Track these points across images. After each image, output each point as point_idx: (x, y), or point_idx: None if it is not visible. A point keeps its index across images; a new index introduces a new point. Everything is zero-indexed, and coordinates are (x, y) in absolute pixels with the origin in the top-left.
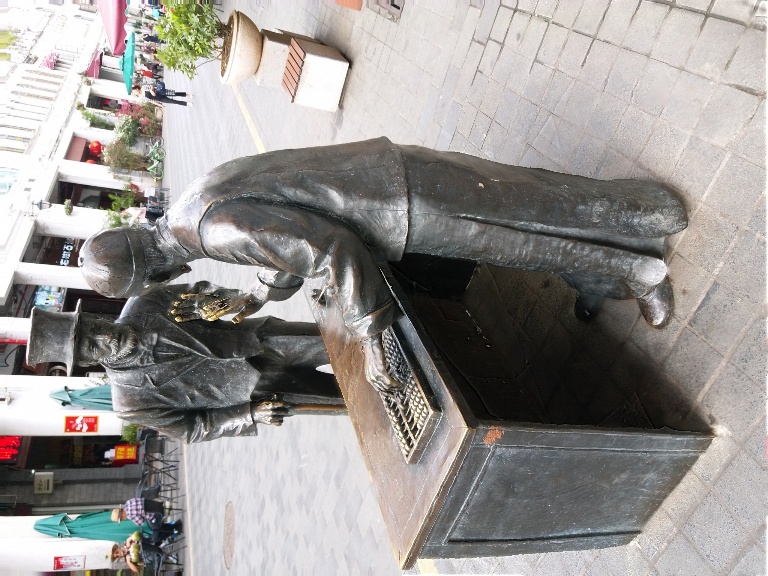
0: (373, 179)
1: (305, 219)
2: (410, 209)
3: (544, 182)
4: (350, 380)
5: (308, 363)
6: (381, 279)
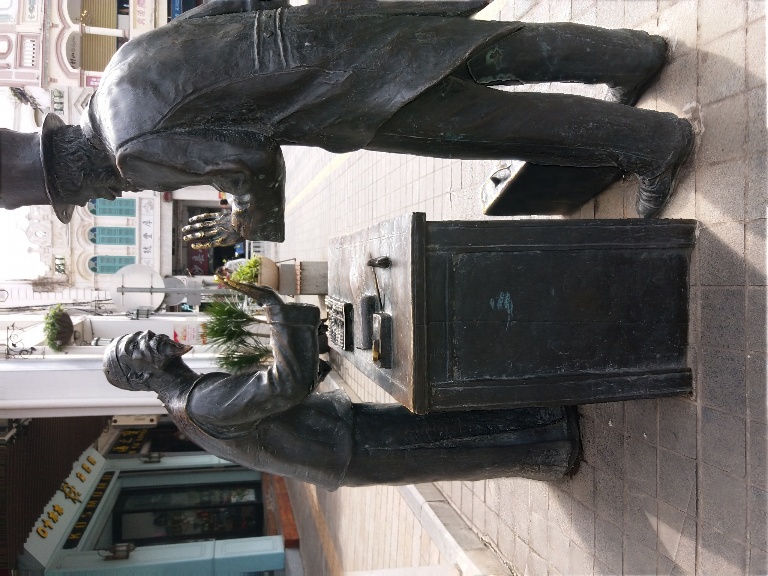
0: None
1: None
2: None
3: None
4: (354, 258)
5: None
6: None
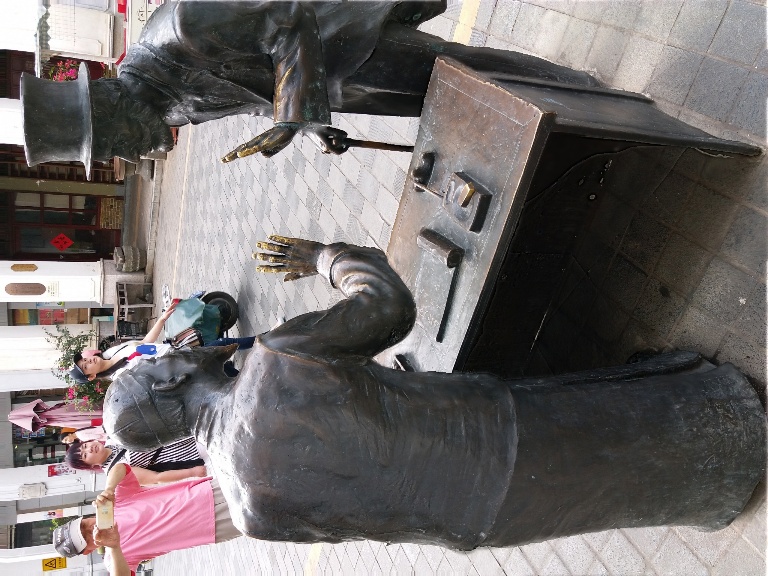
0: None
1: None
2: None
3: None
4: None
5: None
6: None
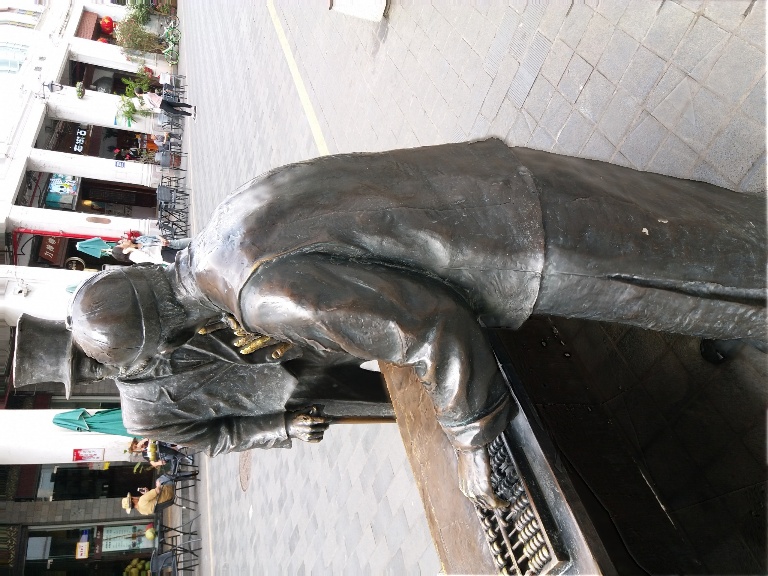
0: (494, 223)
1: (396, 290)
2: (543, 267)
3: (721, 216)
4: (417, 429)
5: (352, 361)
6: (495, 368)
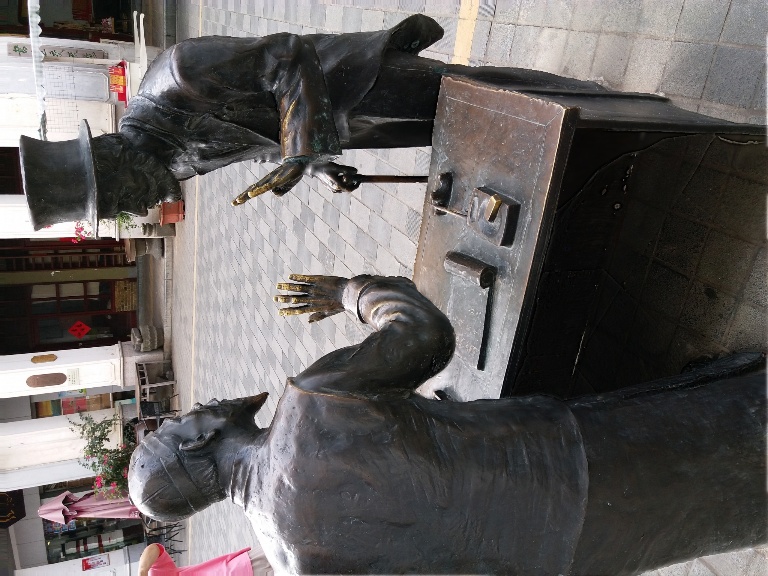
0: None
1: None
2: None
3: None
4: None
5: None
6: None
